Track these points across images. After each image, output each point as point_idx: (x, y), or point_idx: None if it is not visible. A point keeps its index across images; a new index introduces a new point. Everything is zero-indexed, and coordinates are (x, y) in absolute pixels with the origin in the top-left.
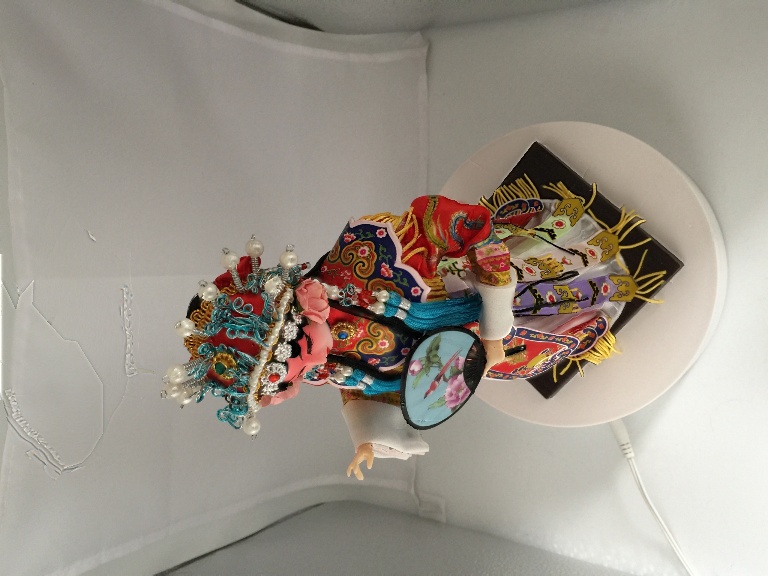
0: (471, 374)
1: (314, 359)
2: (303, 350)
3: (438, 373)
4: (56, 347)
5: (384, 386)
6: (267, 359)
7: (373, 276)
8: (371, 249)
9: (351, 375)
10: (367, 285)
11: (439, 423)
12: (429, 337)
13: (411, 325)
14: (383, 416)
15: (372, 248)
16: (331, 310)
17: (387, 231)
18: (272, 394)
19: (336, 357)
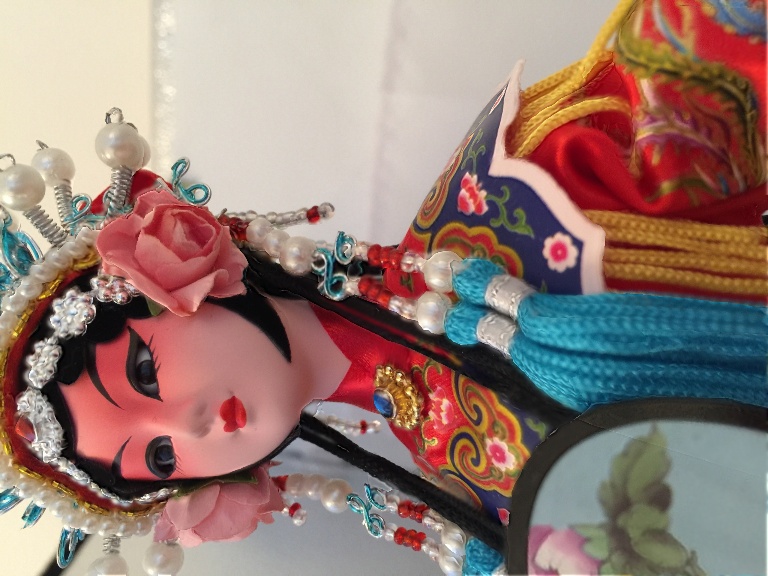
0: None
1: (162, 414)
2: (109, 374)
3: None
4: None
5: None
6: None
7: (442, 220)
8: (461, 150)
9: None
10: (430, 250)
11: None
12: (597, 433)
13: (535, 378)
14: None
15: (464, 147)
16: (361, 329)
17: (506, 88)
18: (114, 495)
19: (415, 481)
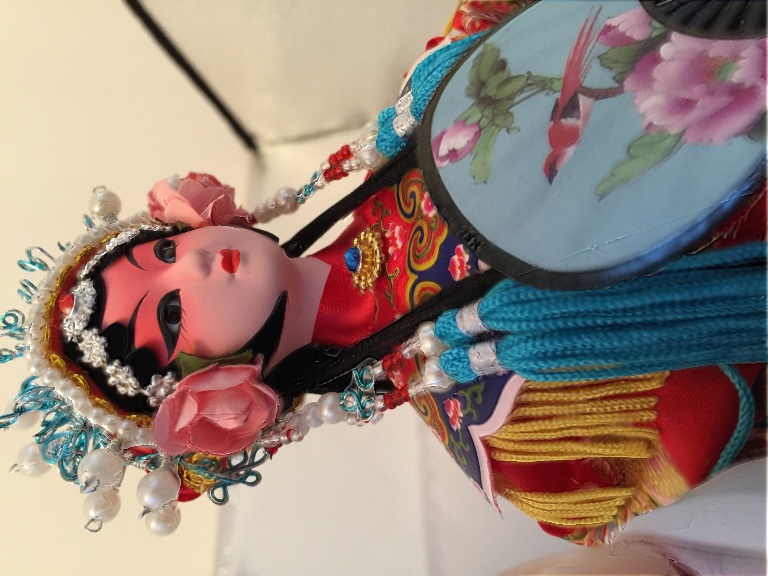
0: (736, 11)
1: None
2: (141, 252)
3: (555, 102)
4: None
5: (505, 292)
6: (57, 279)
7: None
8: None
9: (445, 343)
10: None
11: (727, 213)
12: (457, 73)
13: None
14: (767, 480)
15: None
16: None
17: None
18: (124, 374)
19: None
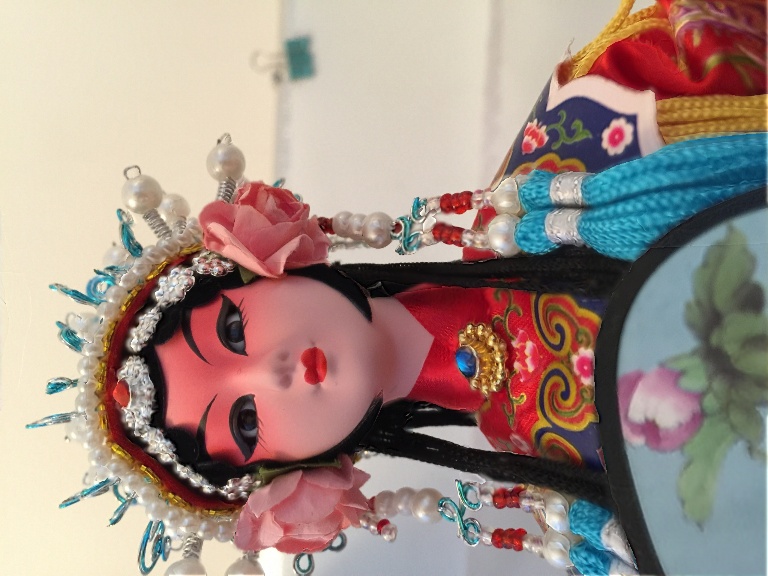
0: None
1: (246, 365)
2: (201, 331)
3: None
4: (5, 378)
5: None
6: (103, 340)
7: (509, 171)
8: None
9: None
10: None
11: None
12: (673, 255)
13: (606, 244)
14: None
15: None
16: (442, 304)
17: None
18: (197, 478)
19: (508, 457)
